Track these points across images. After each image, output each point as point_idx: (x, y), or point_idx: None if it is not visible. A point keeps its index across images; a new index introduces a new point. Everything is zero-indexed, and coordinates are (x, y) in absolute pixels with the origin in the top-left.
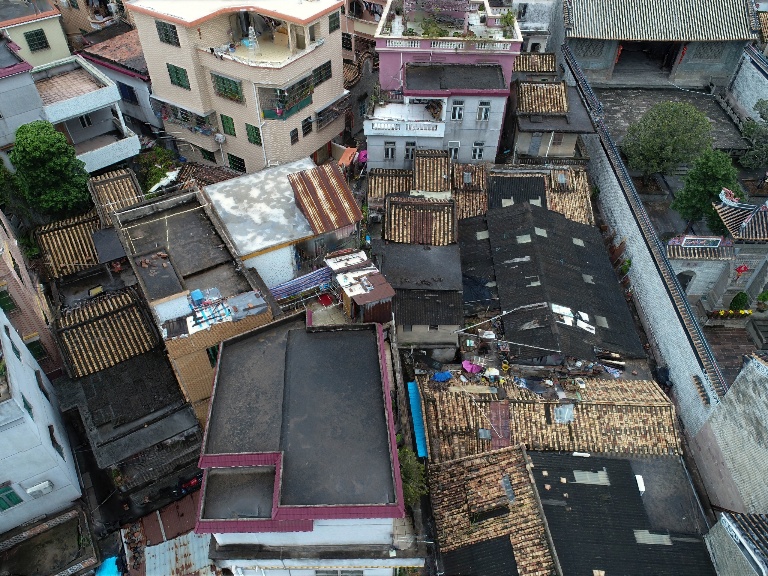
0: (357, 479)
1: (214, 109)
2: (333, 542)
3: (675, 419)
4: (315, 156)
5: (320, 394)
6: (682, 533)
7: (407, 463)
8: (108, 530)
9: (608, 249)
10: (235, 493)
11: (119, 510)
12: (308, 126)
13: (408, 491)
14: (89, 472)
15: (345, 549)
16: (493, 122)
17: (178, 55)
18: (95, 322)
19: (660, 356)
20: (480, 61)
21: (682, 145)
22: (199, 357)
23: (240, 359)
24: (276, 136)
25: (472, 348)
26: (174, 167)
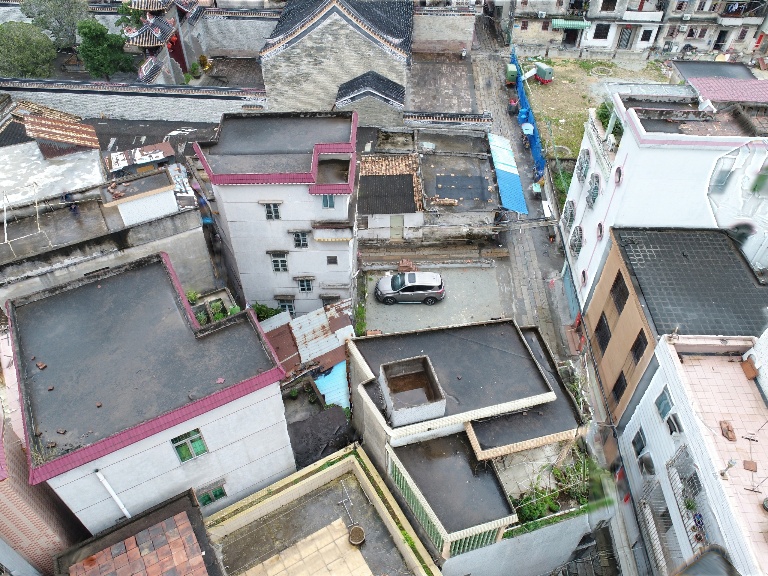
0: (334, 127)
1: None
2: None
3: None
4: None
5: (272, 139)
6: None
7: None
8: None
9: None
10: (330, 179)
11: None
12: None
13: None
14: None
15: None
16: None
17: None
18: None
19: None
20: None
21: (43, 45)
22: None
23: None
24: None
25: None
26: None
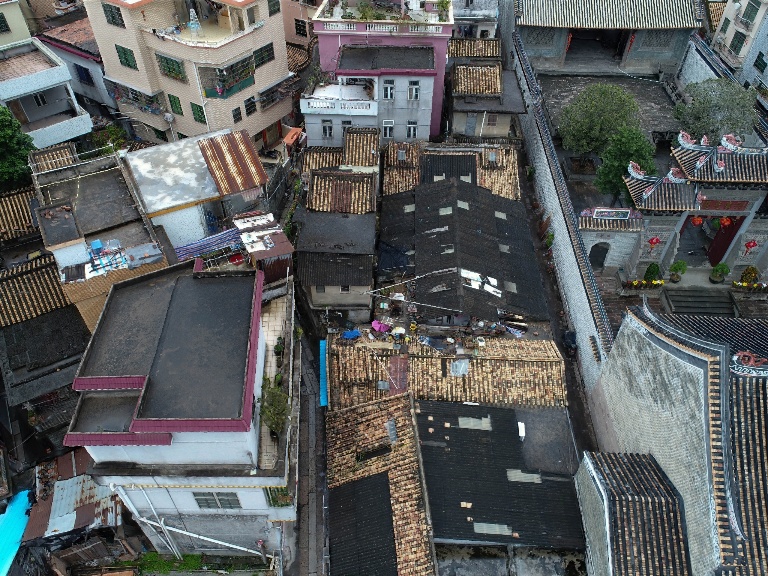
0: (213, 400)
1: (162, 89)
2: (199, 461)
3: (563, 373)
4: (264, 136)
5: (195, 330)
6: (553, 473)
7: (269, 391)
8: (24, 467)
9: (538, 225)
10: (106, 413)
11: (42, 453)
12: (252, 106)
13: (267, 415)
14: (18, 420)
15: (210, 468)
16: (424, 101)
17: (124, 36)
18: (20, 277)
19: (570, 322)
20: (415, 43)
21: (608, 125)
22: (100, 303)
23: (129, 300)
24: (219, 114)
25: (385, 310)
26: (126, 145)
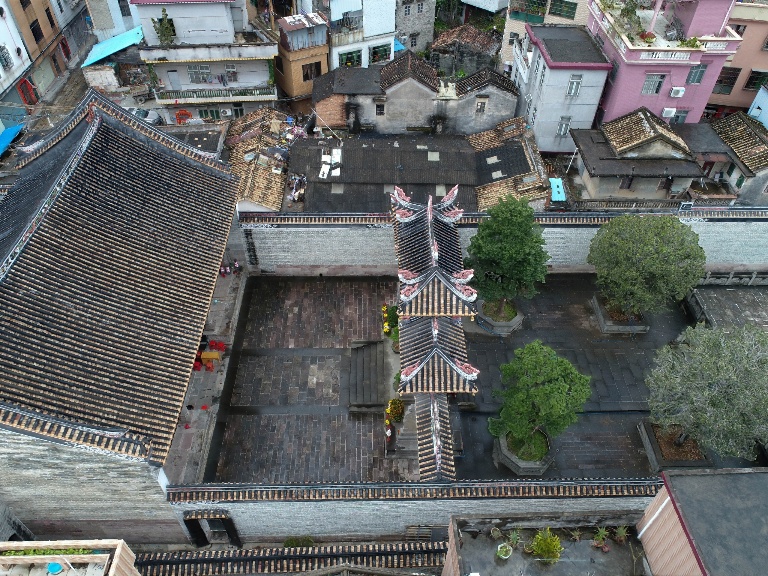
0: None
1: None
2: None
3: None
4: None
5: None
6: None
7: None
8: None
9: None
10: None
11: None
12: None
13: None
14: None
15: None
16: None
17: None
18: None
19: None
20: (614, 55)
21: (601, 241)
22: None
23: None
24: None
25: None
26: None
